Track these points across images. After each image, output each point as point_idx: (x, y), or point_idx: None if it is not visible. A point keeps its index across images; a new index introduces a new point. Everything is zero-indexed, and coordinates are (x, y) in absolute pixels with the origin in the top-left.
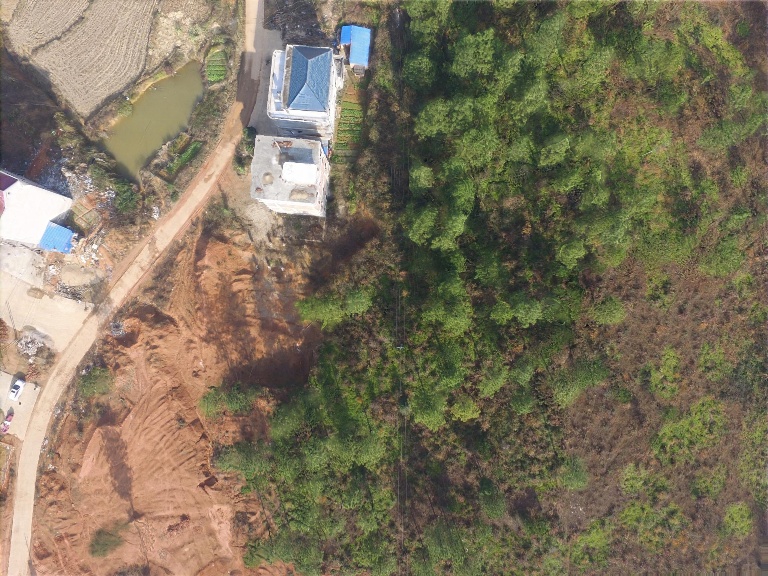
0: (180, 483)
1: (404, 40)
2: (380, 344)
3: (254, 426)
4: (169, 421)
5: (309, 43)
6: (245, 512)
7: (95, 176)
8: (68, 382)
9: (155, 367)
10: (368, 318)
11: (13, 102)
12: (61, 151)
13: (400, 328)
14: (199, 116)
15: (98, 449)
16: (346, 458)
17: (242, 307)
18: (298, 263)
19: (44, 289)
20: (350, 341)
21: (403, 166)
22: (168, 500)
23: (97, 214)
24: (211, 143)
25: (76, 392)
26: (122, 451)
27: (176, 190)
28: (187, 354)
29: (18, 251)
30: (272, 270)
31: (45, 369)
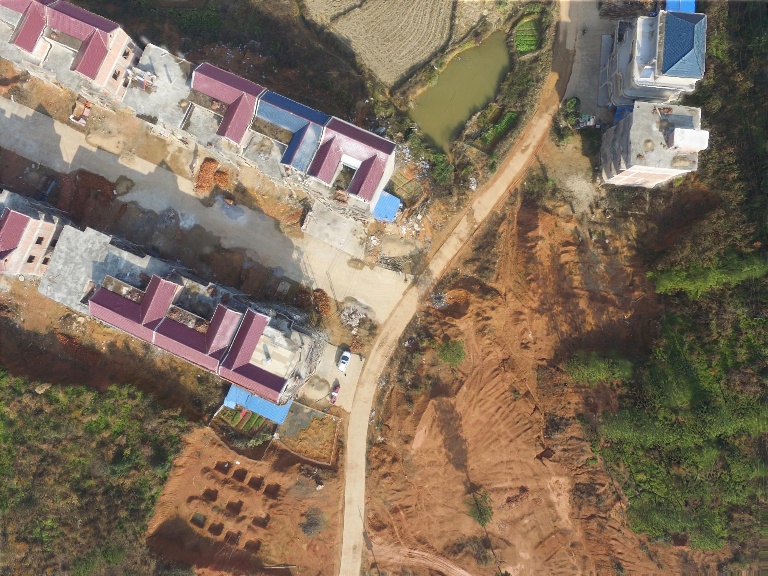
0: (517, 455)
1: (746, 9)
2: (732, 315)
3: (597, 397)
4: (504, 393)
5: (627, 13)
6: (589, 484)
7: (415, 146)
8: (391, 354)
9: (488, 338)
10: (716, 289)
11: (326, 70)
12: (376, 120)
13: (754, 299)
14: (513, 86)
15: (430, 421)
16: (700, 429)
17: (569, 279)
18: (623, 235)
19: (365, 260)
20: (698, 312)
21: (745, 137)
22: (506, 472)
23: (419, 184)
24: (527, 114)
25: (401, 364)
26: (456, 423)
27: (495, 161)
28: (515, 326)
29: (338, 221)
30: (596, 242)
31: (368, 340)
